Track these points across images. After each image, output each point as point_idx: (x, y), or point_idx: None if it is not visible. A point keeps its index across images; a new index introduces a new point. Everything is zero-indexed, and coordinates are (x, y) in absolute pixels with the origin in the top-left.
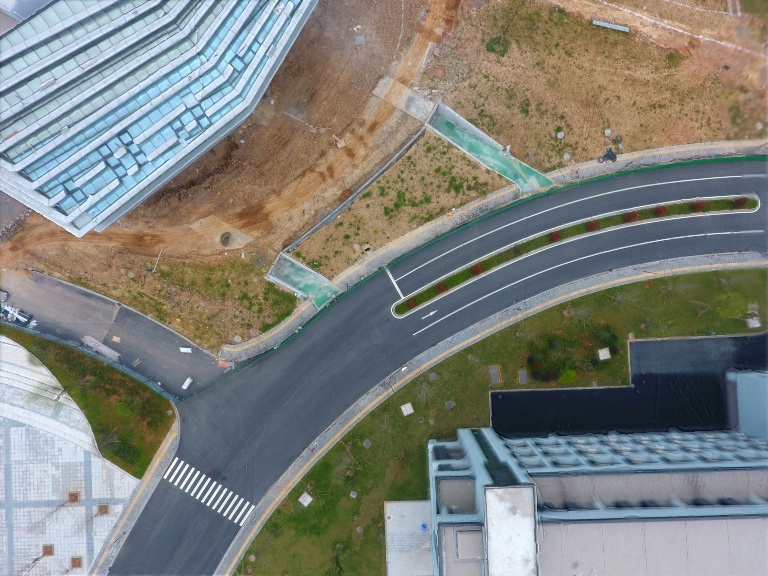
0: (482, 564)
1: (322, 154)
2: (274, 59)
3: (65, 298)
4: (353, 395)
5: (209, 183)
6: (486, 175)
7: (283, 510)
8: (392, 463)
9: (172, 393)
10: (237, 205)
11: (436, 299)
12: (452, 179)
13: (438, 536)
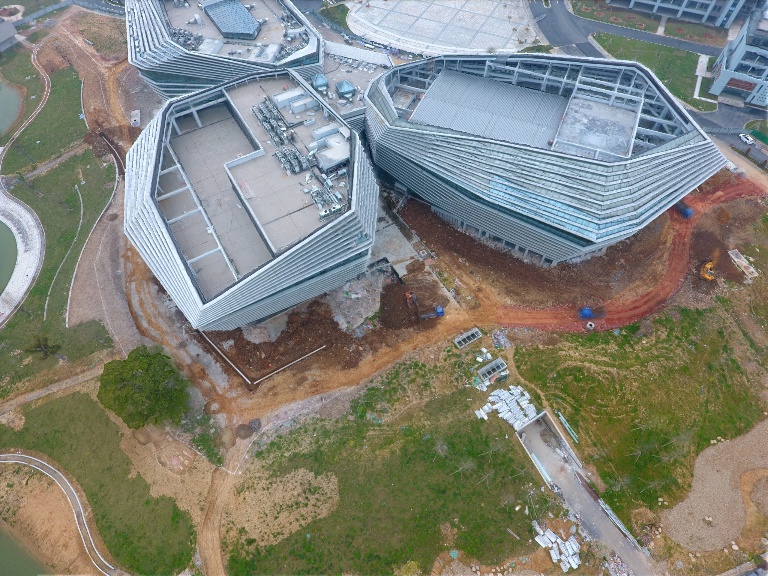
0: None
1: None
2: None
3: None
4: None
5: None
6: None
7: None
8: None
9: None
10: None
11: None
12: None
13: None
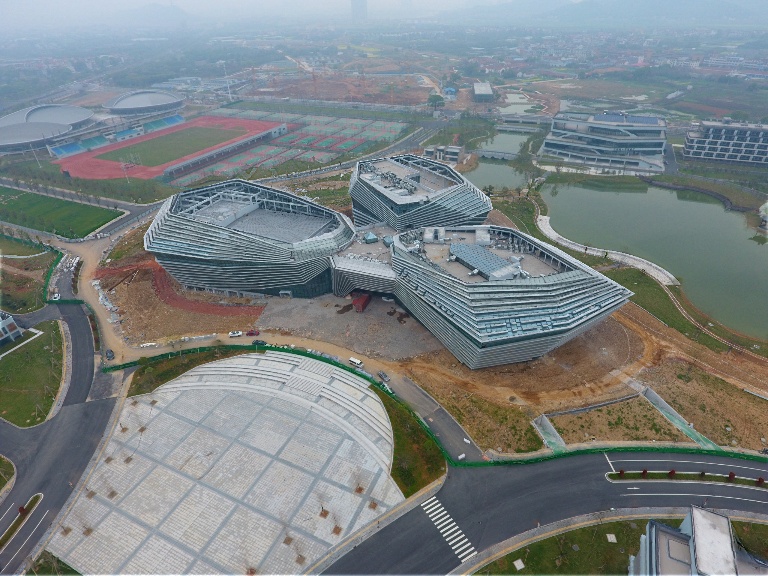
0: (689, 569)
1: (576, 385)
2: (586, 319)
3: (415, 392)
4: (570, 513)
5: (513, 374)
6: (677, 431)
7: (499, 565)
8: (594, 571)
9: (449, 459)
10: (523, 388)
11: (639, 481)
12: (654, 424)
13: (655, 531)
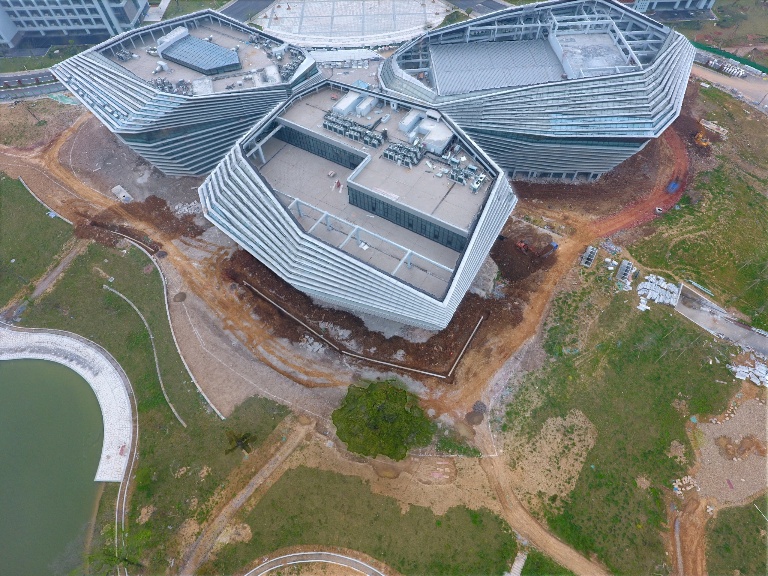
0: None
1: None
2: None
3: None
4: None
5: None
6: None
7: None
8: None
9: None
10: None
11: None
12: None
13: None
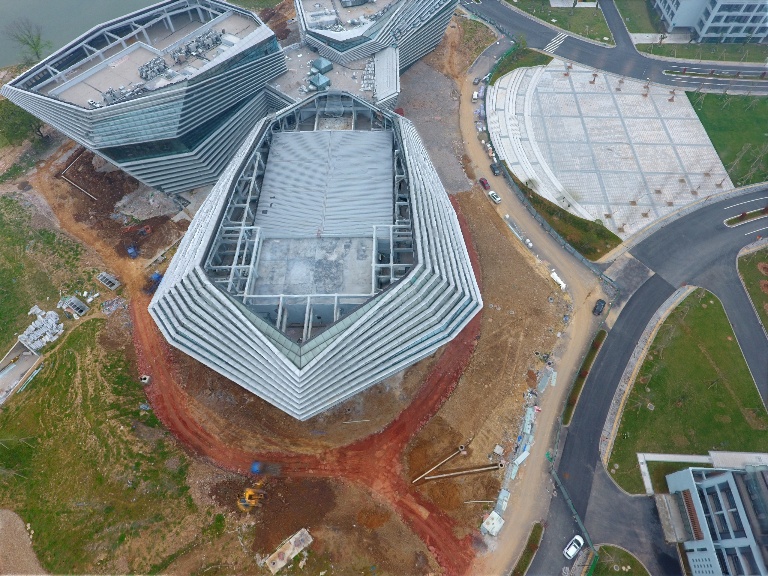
0: None
1: None
2: None
3: None
4: None
5: None
6: None
7: None
8: (536, 4)
9: None
10: None
11: None
12: None
13: None
